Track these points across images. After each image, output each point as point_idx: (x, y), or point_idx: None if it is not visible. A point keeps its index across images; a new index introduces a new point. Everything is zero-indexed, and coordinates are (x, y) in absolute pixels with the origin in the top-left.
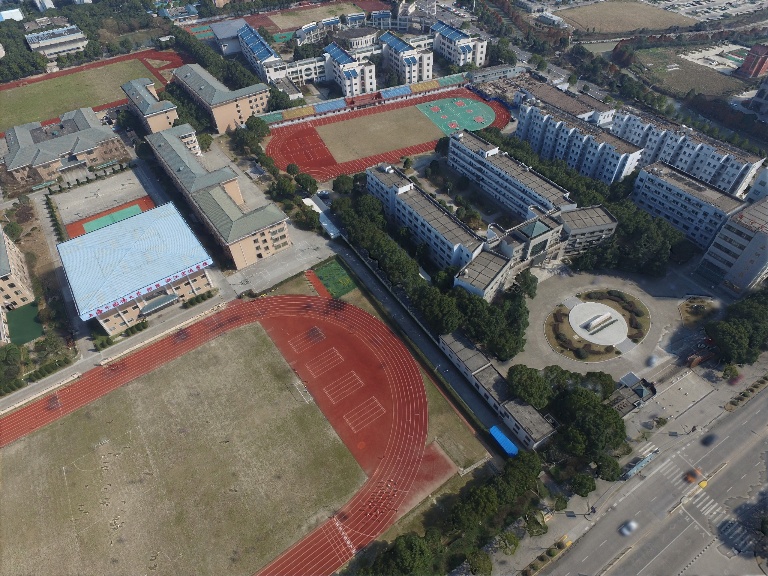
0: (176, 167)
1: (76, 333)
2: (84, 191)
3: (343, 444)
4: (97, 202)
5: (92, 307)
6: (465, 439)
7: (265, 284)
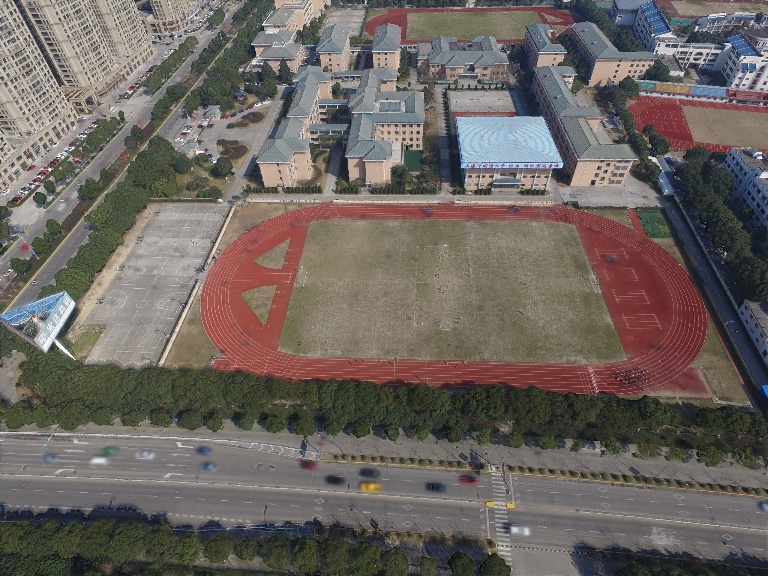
0: (554, 95)
1: (443, 178)
2: (470, 94)
3: (615, 330)
4: (478, 104)
5: (471, 161)
6: (731, 382)
7: (589, 203)
